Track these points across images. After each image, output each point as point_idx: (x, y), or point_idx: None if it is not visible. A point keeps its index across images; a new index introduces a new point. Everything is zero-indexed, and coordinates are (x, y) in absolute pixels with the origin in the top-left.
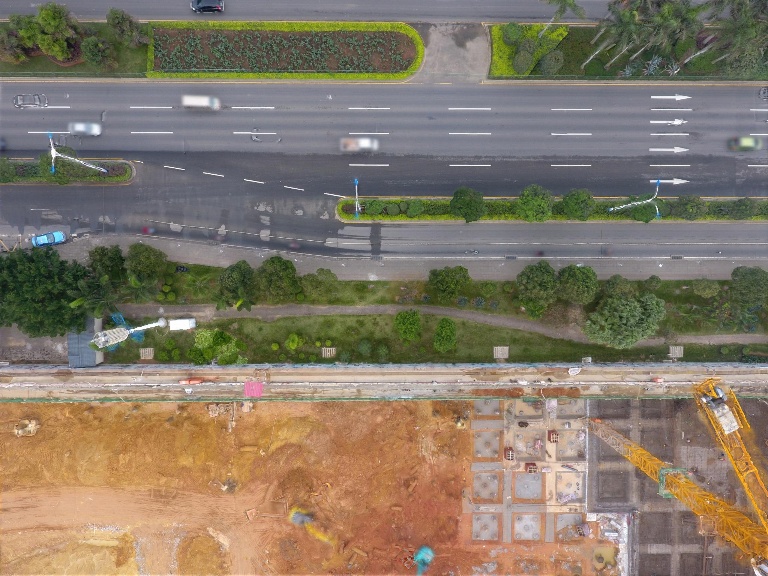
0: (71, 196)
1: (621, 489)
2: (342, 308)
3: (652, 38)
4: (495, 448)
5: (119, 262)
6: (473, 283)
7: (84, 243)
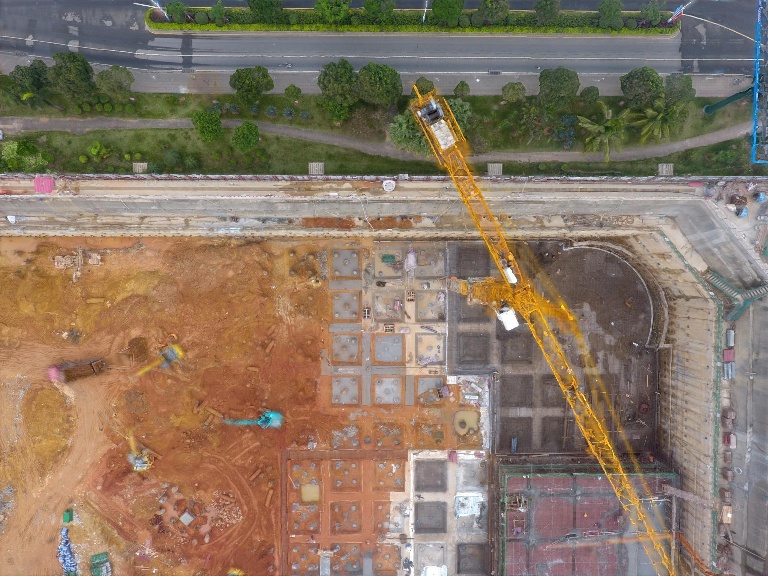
0: None
1: (482, 352)
2: (153, 122)
3: None
4: (354, 310)
5: None
6: None
7: None
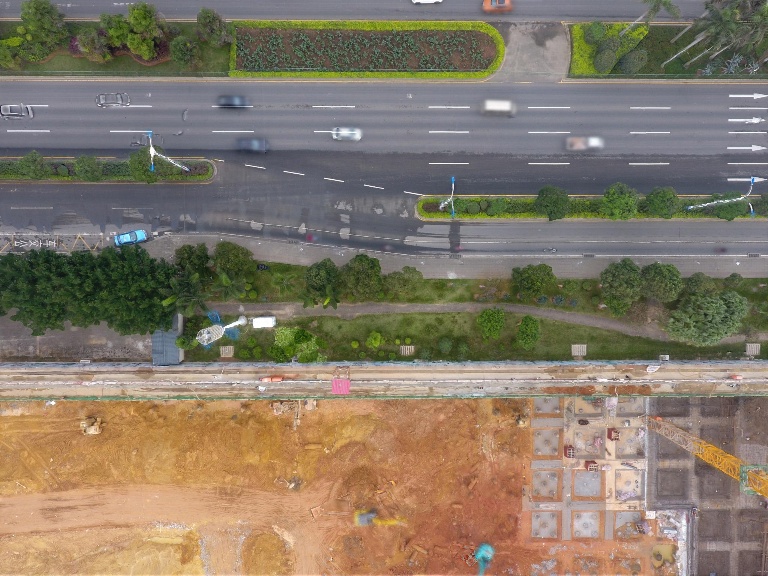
0: (152, 195)
1: (680, 487)
2: (421, 306)
3: (748, 37)
4: (554, 446)
5: (205, 260)
6: None
7: (165, 241)
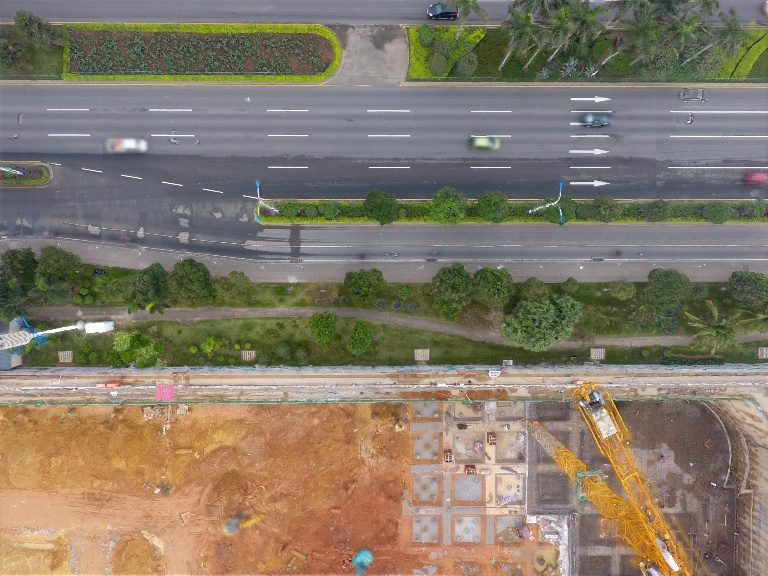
0: None
1: (561, 491)
2: (262, 311)
3: (553, 40)
4: (435, 450)
5: (32, 265)
6: (393, 285)
7: (2, 246)
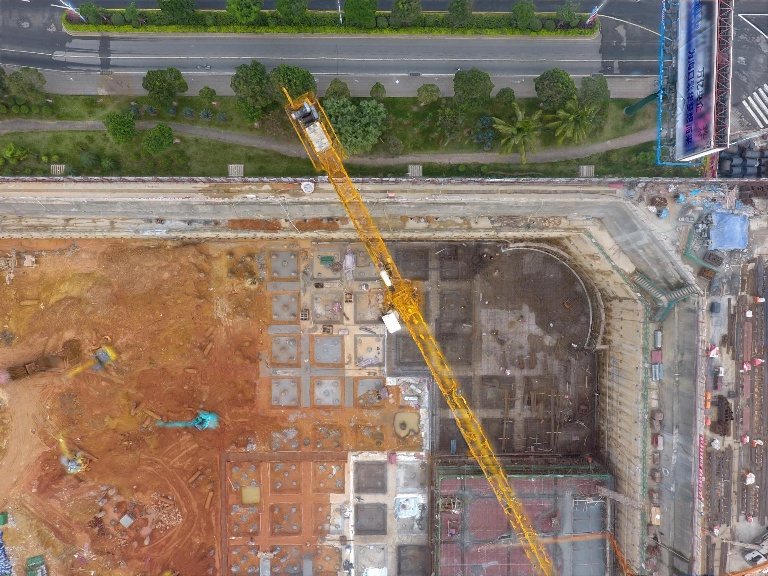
0: None
1: None
2: (71, 123)
3: None
4: (293, 311)
5: None
6: None
7: None
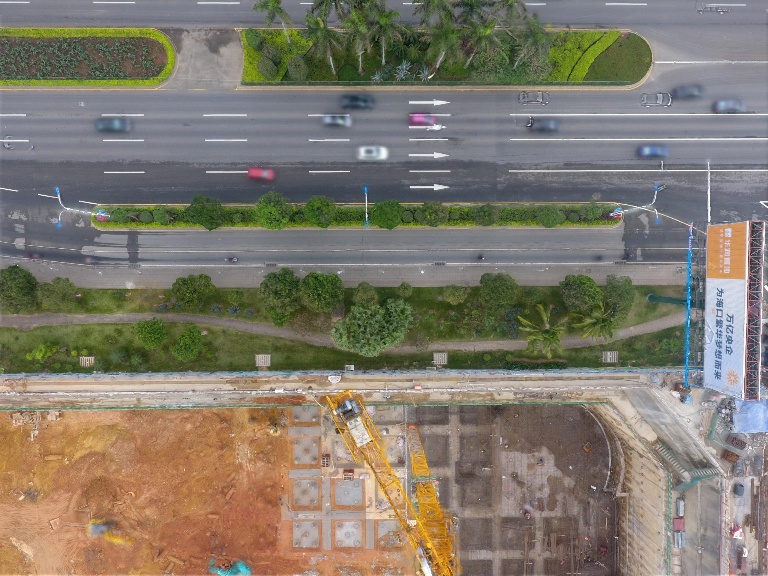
0: None
1: (442, 495)
2: (100, 317)
3: None
4: (314, 455)
5: None
6: None
7: None
